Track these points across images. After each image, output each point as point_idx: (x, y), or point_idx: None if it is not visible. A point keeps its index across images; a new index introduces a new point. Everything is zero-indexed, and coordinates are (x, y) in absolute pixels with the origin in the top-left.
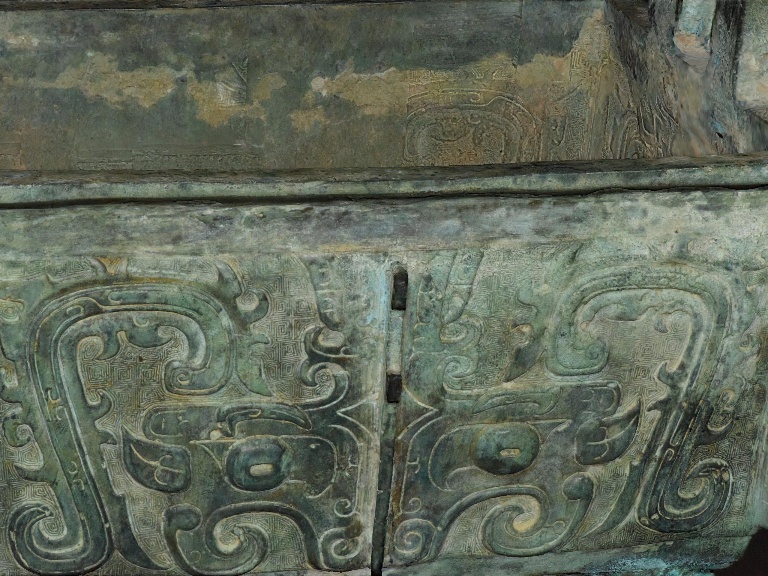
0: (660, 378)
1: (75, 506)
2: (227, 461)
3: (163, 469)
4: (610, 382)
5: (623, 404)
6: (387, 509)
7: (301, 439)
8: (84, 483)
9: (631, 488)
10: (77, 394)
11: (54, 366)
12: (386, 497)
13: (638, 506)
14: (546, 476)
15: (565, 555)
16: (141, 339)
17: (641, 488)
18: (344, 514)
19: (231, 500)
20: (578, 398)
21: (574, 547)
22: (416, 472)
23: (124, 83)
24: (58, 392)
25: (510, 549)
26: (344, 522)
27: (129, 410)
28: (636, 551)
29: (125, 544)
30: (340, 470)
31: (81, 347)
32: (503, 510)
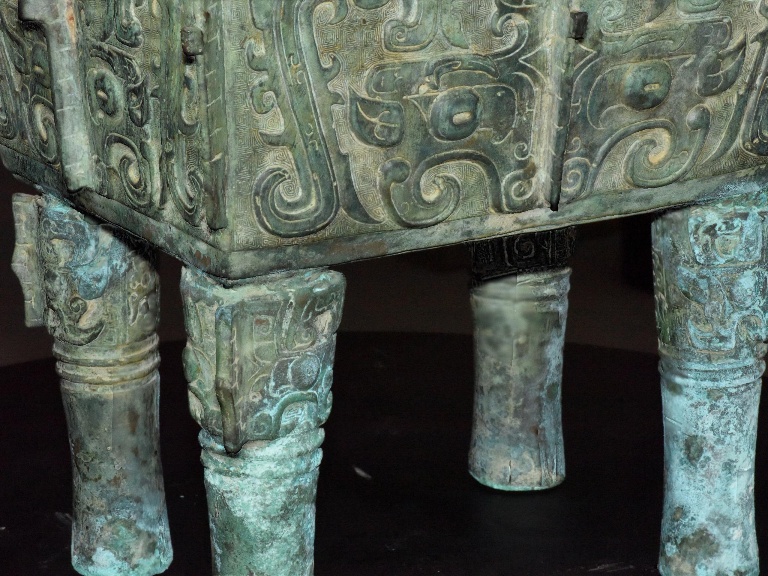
0: (761, 11)
1: (309, 167)
2: (432, 113)
3: (382, 125)
4: (724, 18)
5: (733, 38)
6: (565, 144)
7: (490, 88)
8: (318, 144)
9: (738, 116)
10: (314, 58)
11: (296, 33)
12: (565, 133)
13: (742, 132)
14: (675, 109)
15: (685, 184)
16: (366, 2)
17: (744, 116)
18: (522, 157)
19: (434, 151)
20: (701, 34)
21: (694, 175)
22: (578, 113)
23: None
24: (298, 57)
25: (646, 181)
26: (522, 165)
27: (355, 71)
28: (738, 176)
29: (349, 201)
30: (519, 115)
31: (316, 14)
32: (642, 144)
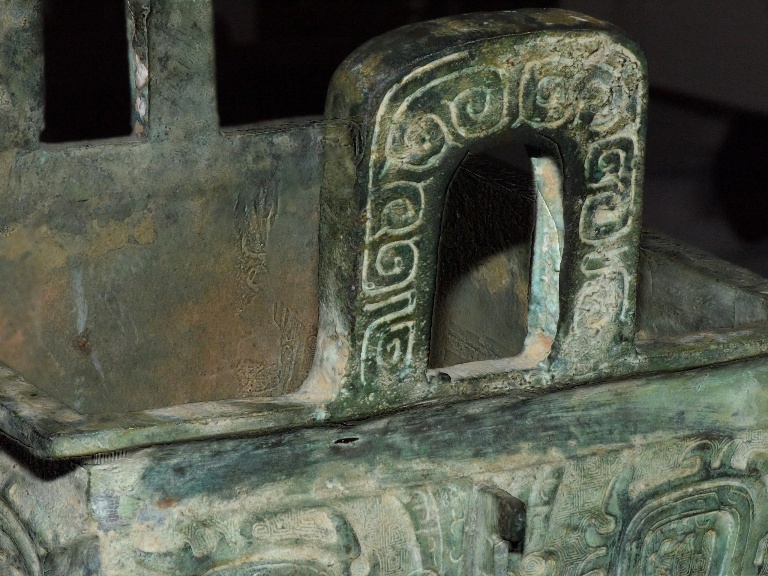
0: None
1: None
2: None
3: None
4: None
5: None
6: None
7: None
8: None
9: None
10: None
11: None
12: None
13: None
14: None
15: None
16: None
17: None
18: None
19: None
20: None
21: None
22: None
23: (479, 259)
24: None
25: None
26: None
27: None
28: None
29: None
30: None
31: None
32: None
